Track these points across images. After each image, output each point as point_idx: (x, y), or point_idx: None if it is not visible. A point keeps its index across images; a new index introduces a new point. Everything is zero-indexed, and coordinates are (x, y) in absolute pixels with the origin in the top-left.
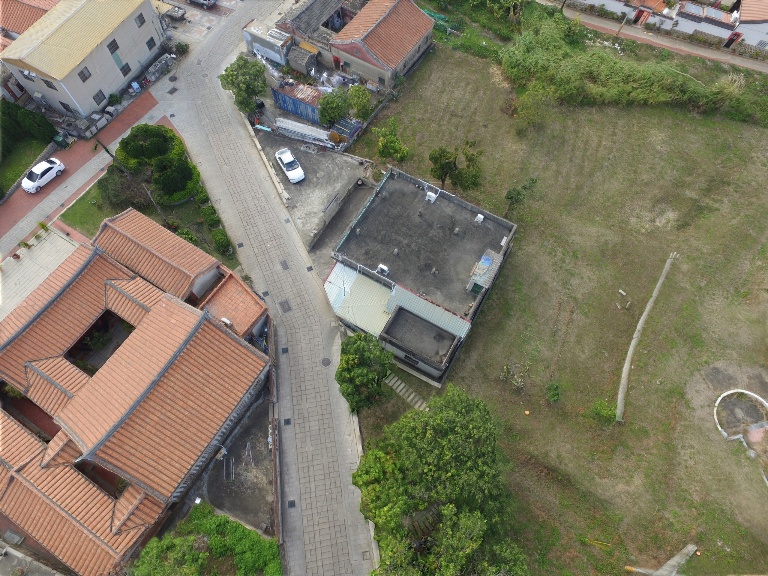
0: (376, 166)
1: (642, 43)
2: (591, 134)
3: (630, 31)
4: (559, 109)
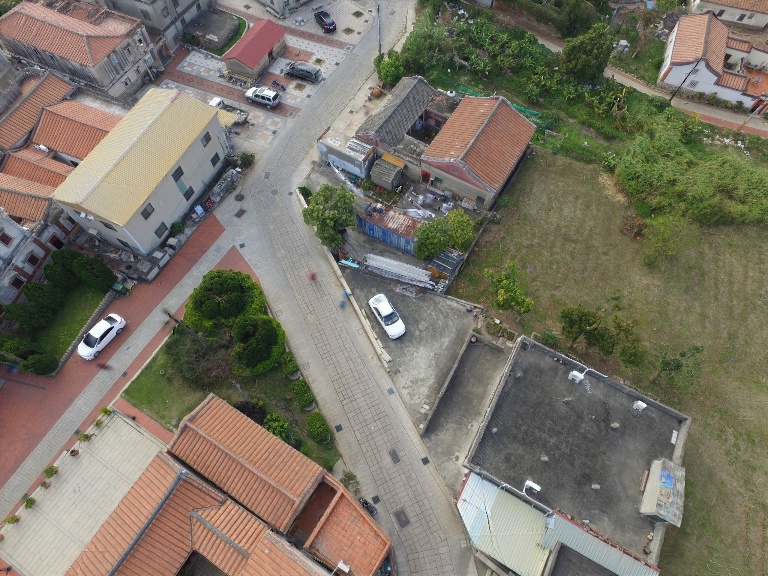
0: (486, 312)
1: (767, 139)
2: (734, 263)
3: (748, 122)
4: (690, 230)
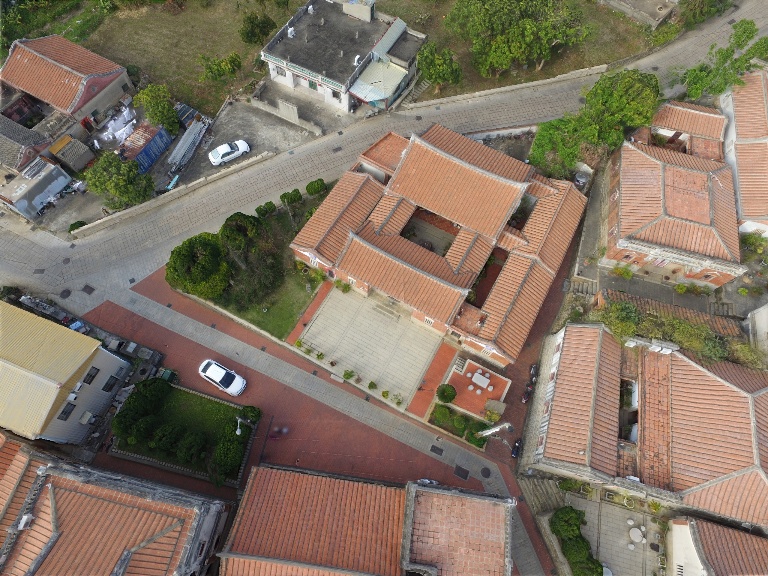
0: (233, 95)
1: None
2: None
3: None
4: None
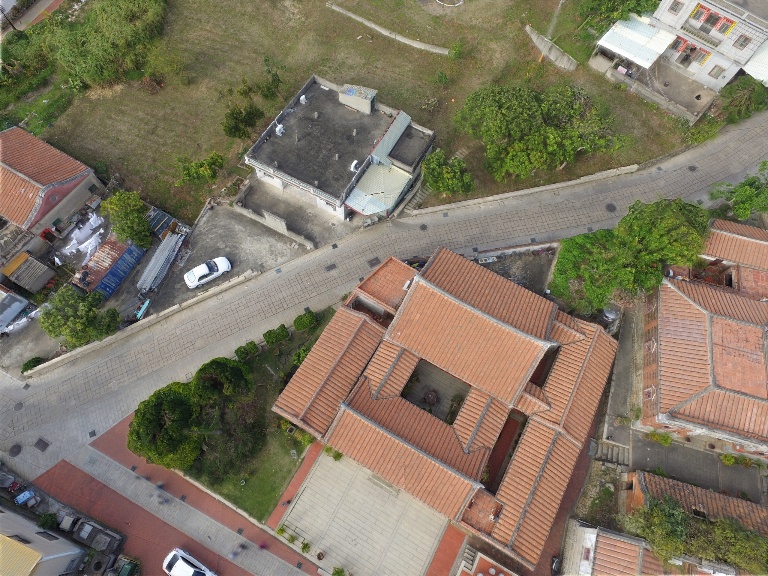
0: (214, 197)
1: None
2: (197, 34)
3: None
4: None
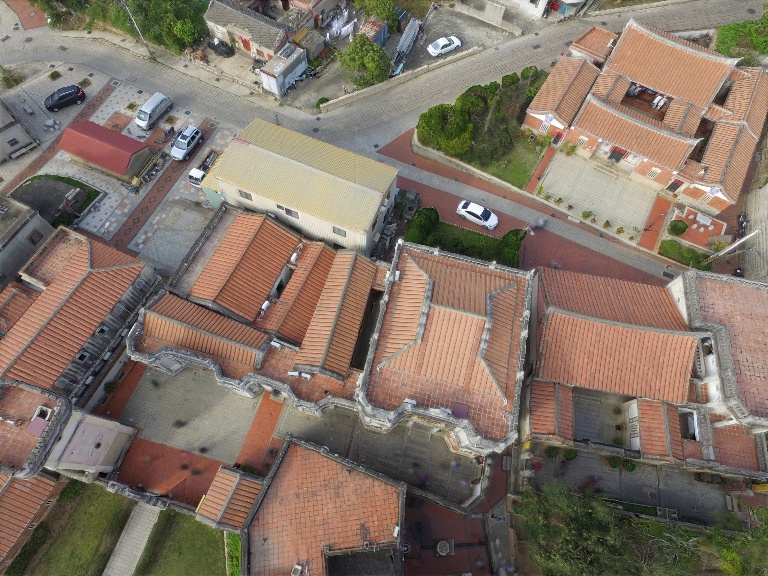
0: None
1: None
2: None
3: None
4: None
